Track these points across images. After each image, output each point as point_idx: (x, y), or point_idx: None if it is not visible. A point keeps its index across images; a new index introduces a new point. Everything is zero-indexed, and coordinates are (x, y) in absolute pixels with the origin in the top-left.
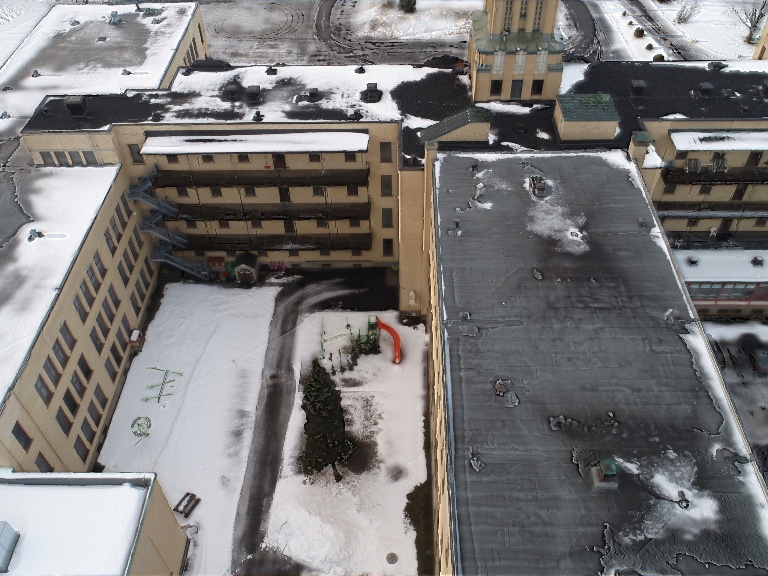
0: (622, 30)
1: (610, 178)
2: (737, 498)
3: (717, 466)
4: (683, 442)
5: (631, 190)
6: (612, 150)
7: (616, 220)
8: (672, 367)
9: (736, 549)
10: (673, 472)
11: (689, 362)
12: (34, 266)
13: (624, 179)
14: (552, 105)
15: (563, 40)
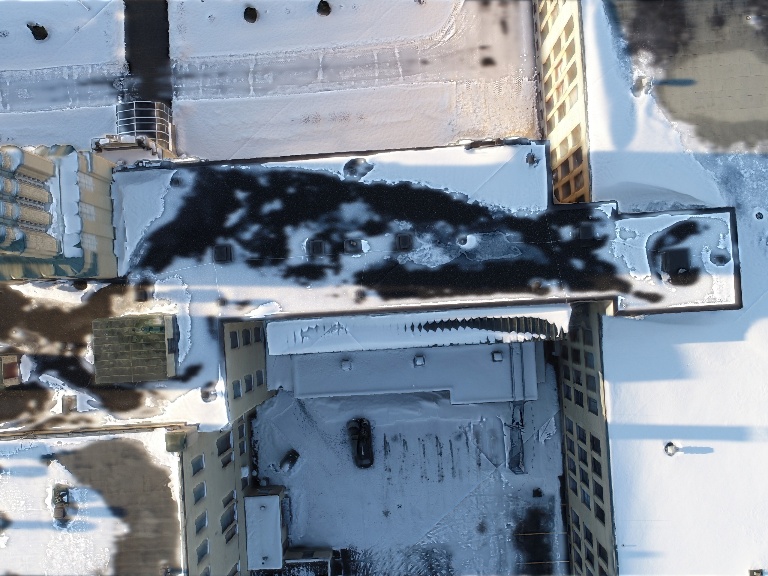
0: None
1: (146, 484)
2: None
3: None
4: None
5: (166, 508)
6: (155, 431)
7: (141, 562)
8: None
9: None
10: None
11: None
12: None
13: (162, 486)
14: (112, 283)
15: None
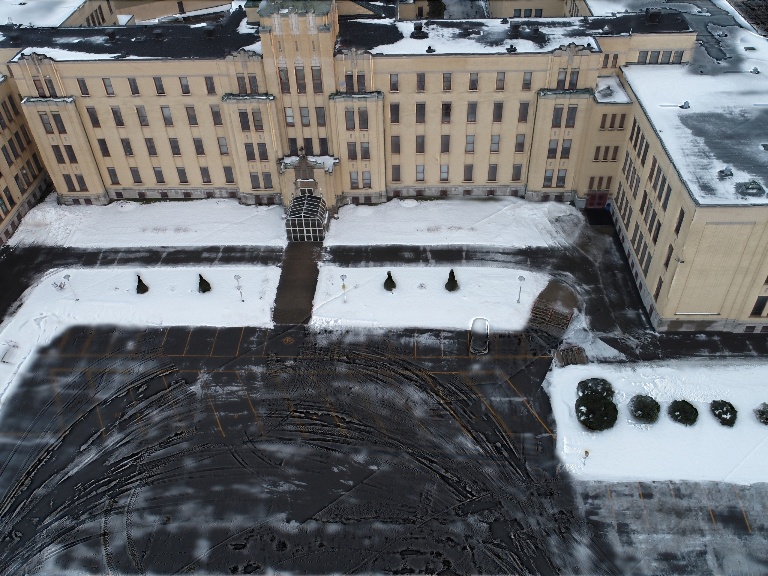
0: None
1: None
2: None
3: None
4: None
5: None
6: None
7: None
8: None
9: None
10: None
11: None
12: (610, 4)
13: None
14: None
15: (41, 569)
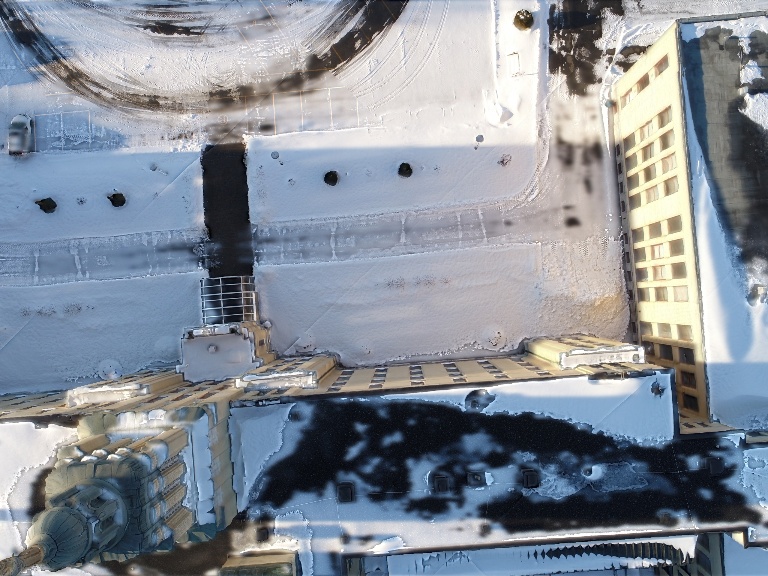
0: None
1: None
2: None
3: None
4: None
5: None
6: None
7: None
8: None
9: None
10: None
11: None
12: None
13: None
14: None
15: None
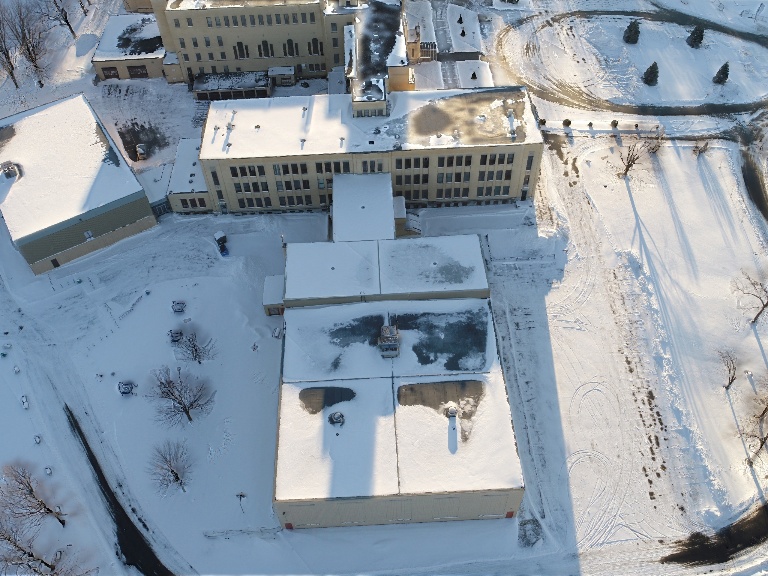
0: (624, 121)
1: None
2: (194, 6)
3: (202, 5)
4: (209, 2)
5: None
6: None
7: None
8: (231, 2)
9: (183, 5)
10: (202, 0)
11: (232, 4)
12: None
13: (309, 1)
14: None
15: (601, 97)
